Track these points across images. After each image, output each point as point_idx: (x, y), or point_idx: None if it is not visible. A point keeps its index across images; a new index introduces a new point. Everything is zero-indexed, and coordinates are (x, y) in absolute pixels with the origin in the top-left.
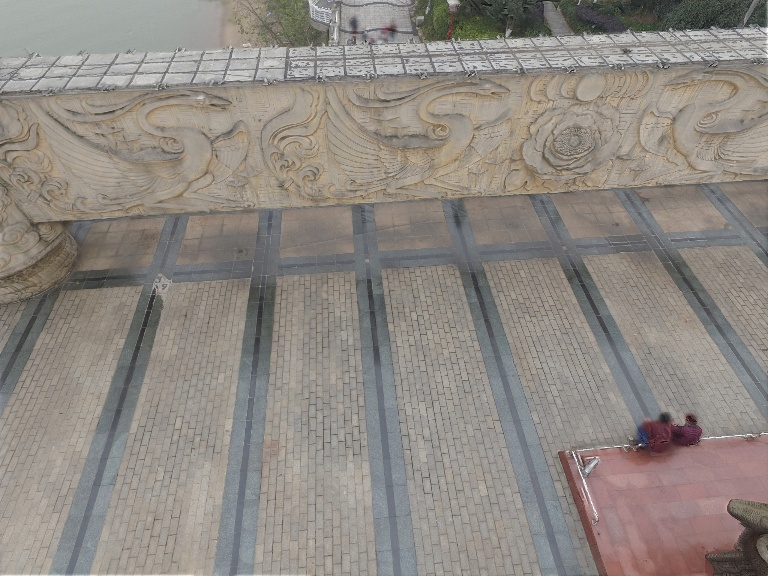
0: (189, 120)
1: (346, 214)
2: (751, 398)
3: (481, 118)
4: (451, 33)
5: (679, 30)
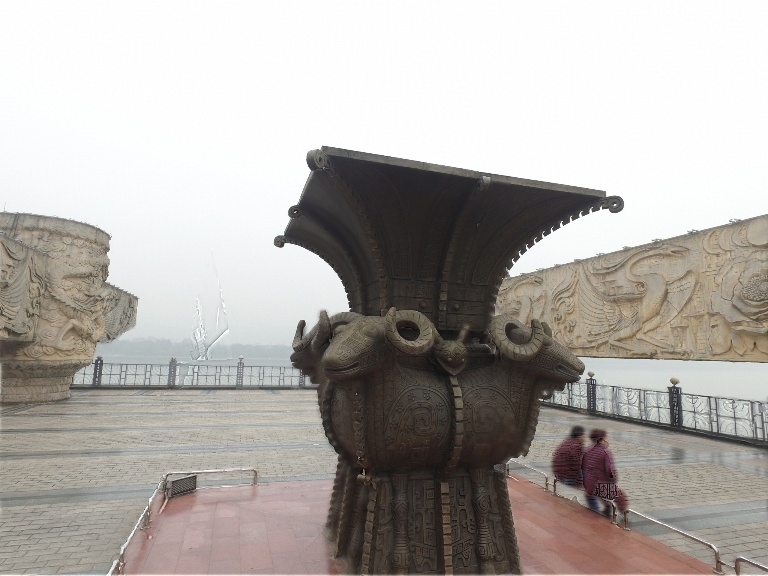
0: (528, 292)
1: (646, 429)
2: None
3: (672, 275)
4: None
5: None
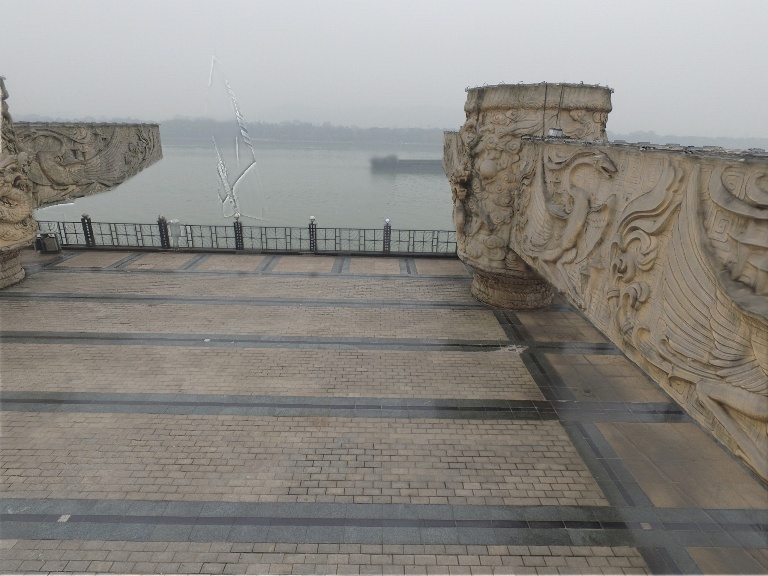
0: (590, 184)
1: (754, 500)
2: None
3: None
4: None
5: None
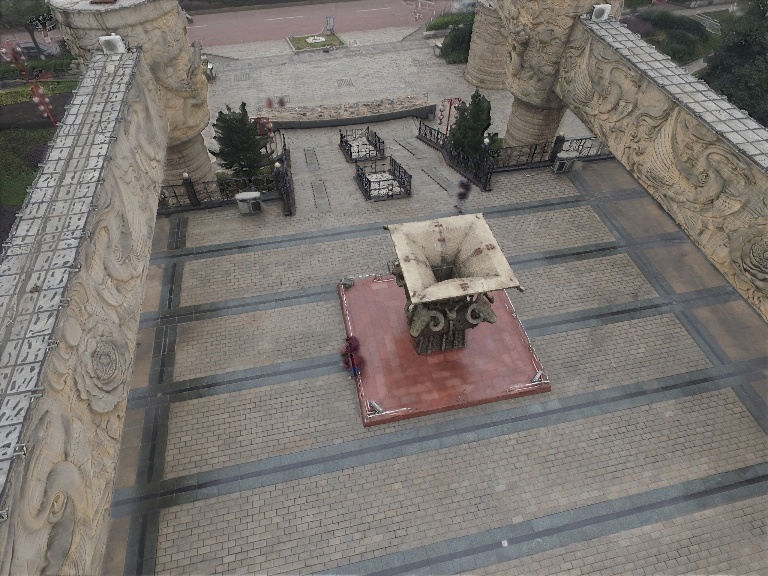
0: None
1: None
2: (317, 302)
3: (58, 450)
4: None
5: (9, 239)
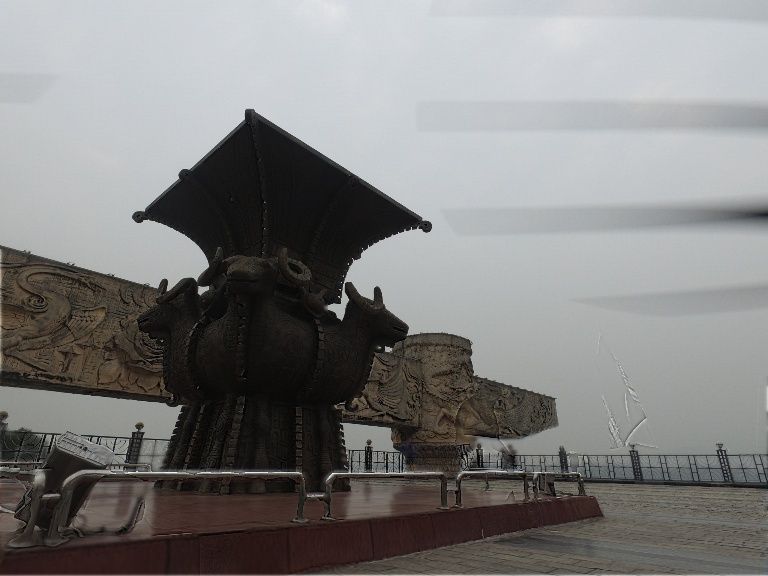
0: None
1: None
2: None
3: None
4: None
5: None
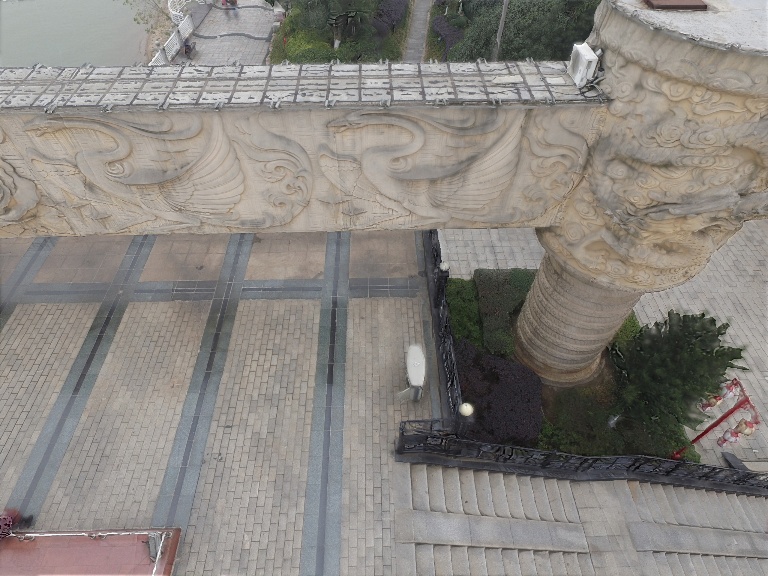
0: None
1: None
2: (160, 485)
3: None
4: (285, 41)
5: None
